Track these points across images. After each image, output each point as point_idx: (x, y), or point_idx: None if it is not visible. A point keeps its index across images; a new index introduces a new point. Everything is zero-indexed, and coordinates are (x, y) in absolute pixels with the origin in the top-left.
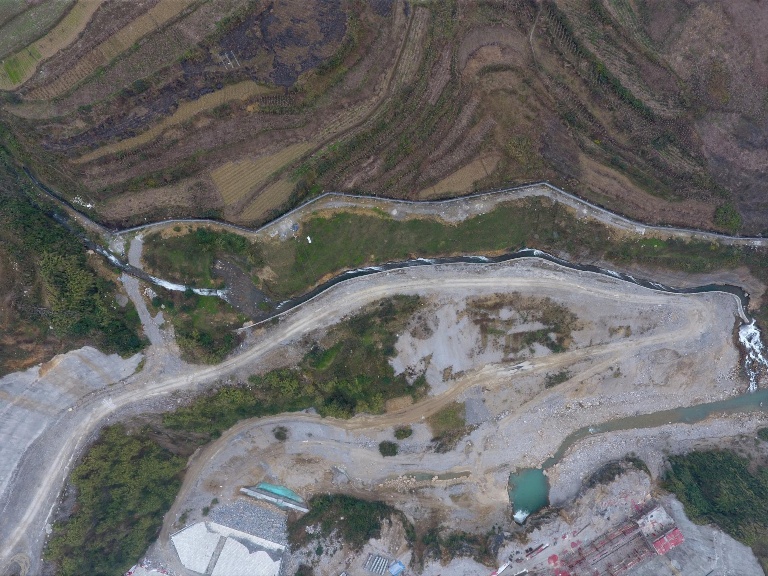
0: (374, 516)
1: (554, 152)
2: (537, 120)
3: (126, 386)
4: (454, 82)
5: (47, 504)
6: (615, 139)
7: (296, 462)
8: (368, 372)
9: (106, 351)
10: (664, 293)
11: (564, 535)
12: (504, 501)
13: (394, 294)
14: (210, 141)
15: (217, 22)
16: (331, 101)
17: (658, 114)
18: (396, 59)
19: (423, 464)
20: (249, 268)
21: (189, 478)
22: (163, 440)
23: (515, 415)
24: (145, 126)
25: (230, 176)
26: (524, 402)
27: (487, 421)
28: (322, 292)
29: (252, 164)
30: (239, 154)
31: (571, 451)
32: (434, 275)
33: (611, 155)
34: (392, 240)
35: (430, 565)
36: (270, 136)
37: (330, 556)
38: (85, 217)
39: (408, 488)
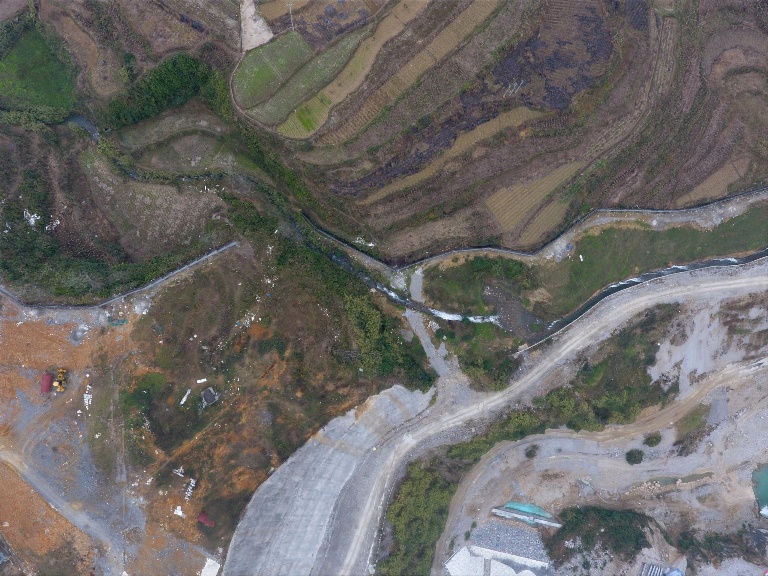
0: (635, 525)
1: None
2: None
3: (423, 420)
4: (704, 88)
5: (366, 545)
6: None
7: (543, 478)
8: (633, 383)
9: (412, 388)
10: None
11: None
12: (750, 498)
13: (656, 304)
14: (487, 170)
15: (492, 52)
16: (599, 119)
17: None
18: (653, 71)
19: (668, 469)
20: (519, 291)
21: (454, 504)
22: (443, 470)
23: (752, 412)
24: (429, 161)
25: (505, 202)
26: (762, 398)
27: (725, 420)
28: (590, 308)
29: (525, 189)
30: (511, 180)
31: None
32: (689, 281)
33: None
34: (654, 251)
35: (704, 569)
36: (542, 159)
37: (600, 569)
38: (368, 256)
39: (655, 494)
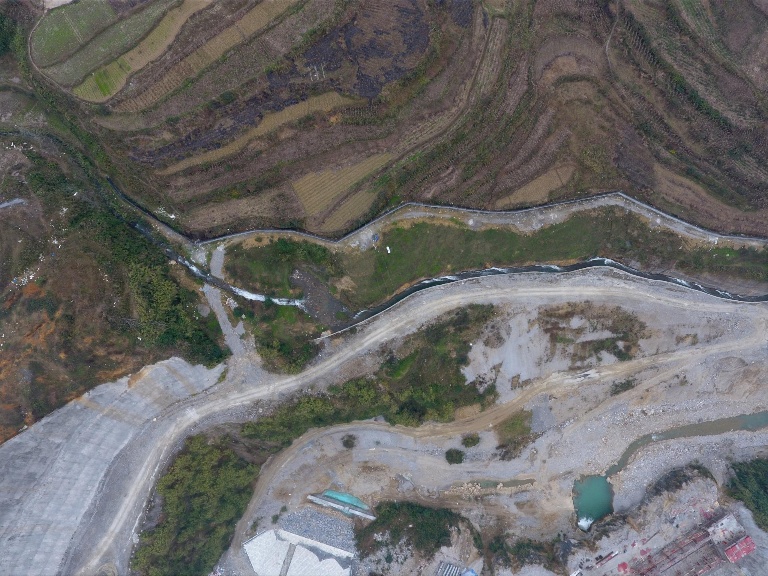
0: (443, 524)
1: (629, 162)
2: (612, 130)
3: (209, 396)
4: (531, 92)
5: (134, 514)
6: (691, 149)
7: (362, 470)
8: (442, 381)
9: (193, 362)
10: (732, 301)
11: (633, 543)
12: (569, 508)
13: (469, 303)
14: (293, 152)
15: (303, 34)
16: (413, 112)
17: (735, 124)
18: (475, 70)
19: (488, 472)
20: (327, 278)
21: (260, 486)
22: (240, 449)
23: (579, 423)
24: (231, 137)
25: (312, 187)
26: (589, 410)
27: (552, 429)
28: (399, 302)
29: (334, 175)
30: (321, 165)
31: (635, 458)
32: (507, 284)
33: (686, 165)
34: (468, 250)
35: (501, 573)
36: (352, 147)
37: (401, 564)
38: (168, 228)
39: (473, 495)
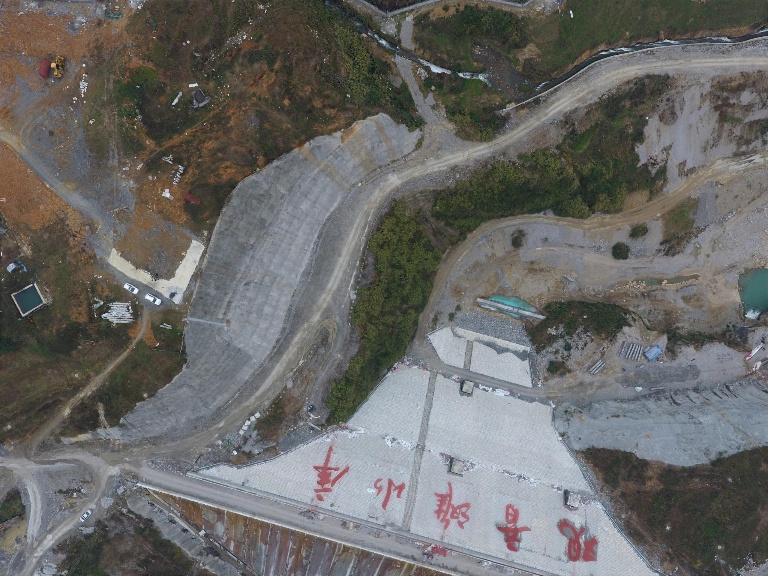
0: (618, 312)
1: None
2: None
3: (408, 162)
4: None
5: (348, 272)
6: None
7: (528, 271)
8: (620, 156)
9: (398, 119)
10: None
11: None
12: (735, 300)
13: (646, 74)
14: None
15: None
16: None
17: None
18: None
19: (654, 267)
20: (509, 50)
21: (439, 280)
22: (428, 230)
23: (742, 215)
24: None
25: None
26: (752, 200)
27: (714, 222)
28: (579, 72)
29: None
30: None
31: None
32: (681, 56)
33: None
34: (645, 16)
35: (684, 350)
36: None
37: (581, 349)
38: None
39: (640, 292)
